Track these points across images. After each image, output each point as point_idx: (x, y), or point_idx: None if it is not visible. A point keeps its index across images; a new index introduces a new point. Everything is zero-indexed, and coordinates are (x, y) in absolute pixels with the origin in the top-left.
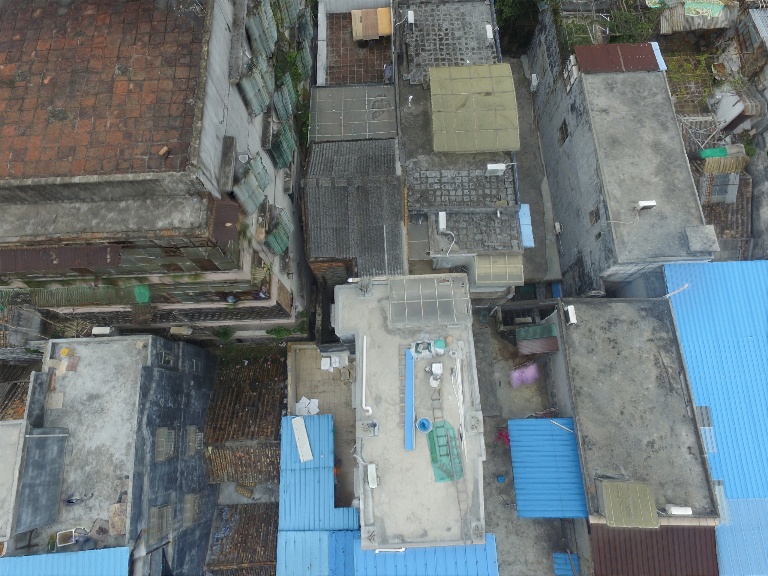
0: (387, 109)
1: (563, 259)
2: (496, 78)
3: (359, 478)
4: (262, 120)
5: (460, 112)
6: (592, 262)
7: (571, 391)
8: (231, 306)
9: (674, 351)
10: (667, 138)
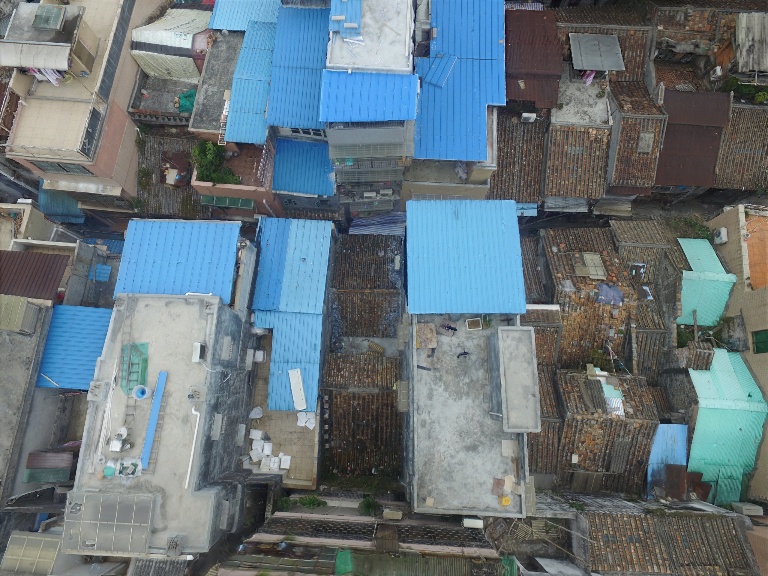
0: None
1: None
2: None
3: (212, 351)
4: None
5: None
6: None
7: (23, 411)
8: (291, 538)
9: None
10: None
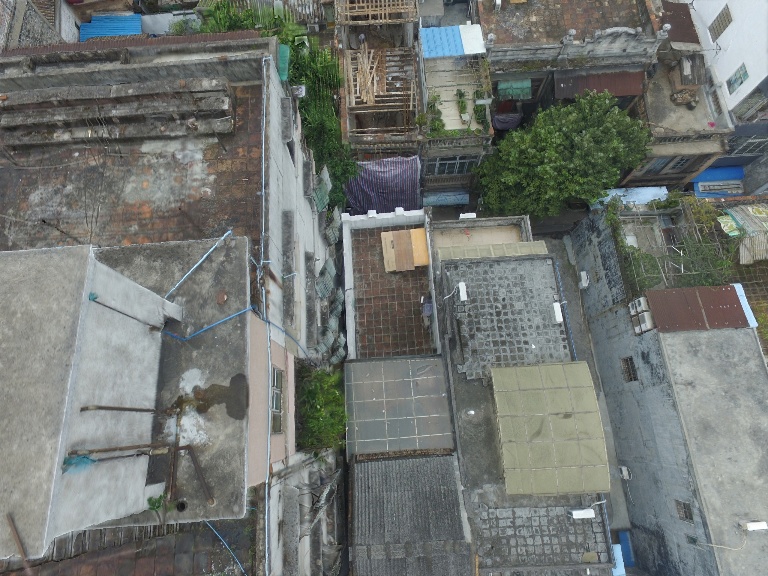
0: (437, 396)
1: (632, 509)
2: (574, 389)
3: None
4: (310, 566)
5: (536, 443)
6: (681, 559)
7: None
8: None
9: None
10: (767, 422)
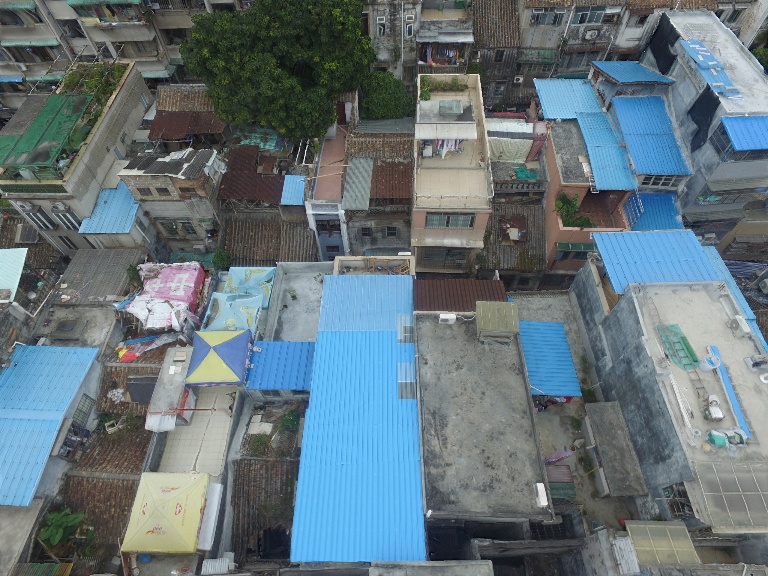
0: None
1: None
2: None
3: None
4: None
5: None
6: None
7: None
8: None
9: (426, 451)
10: None
